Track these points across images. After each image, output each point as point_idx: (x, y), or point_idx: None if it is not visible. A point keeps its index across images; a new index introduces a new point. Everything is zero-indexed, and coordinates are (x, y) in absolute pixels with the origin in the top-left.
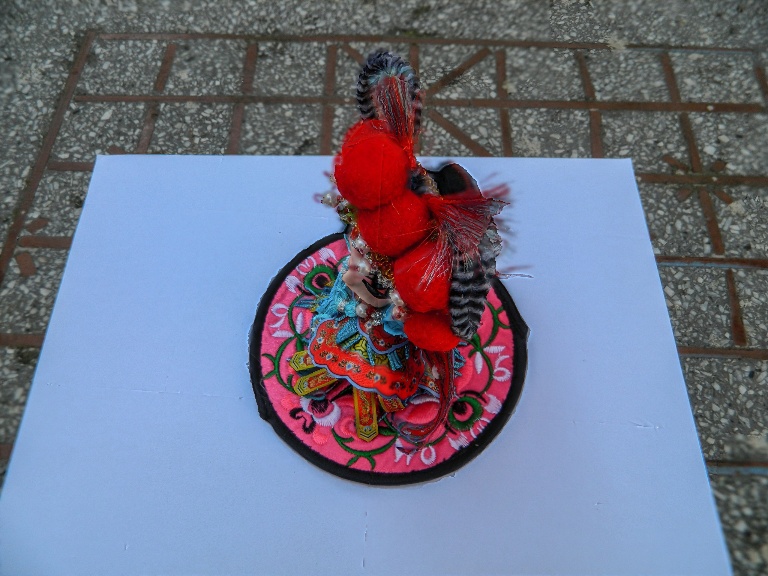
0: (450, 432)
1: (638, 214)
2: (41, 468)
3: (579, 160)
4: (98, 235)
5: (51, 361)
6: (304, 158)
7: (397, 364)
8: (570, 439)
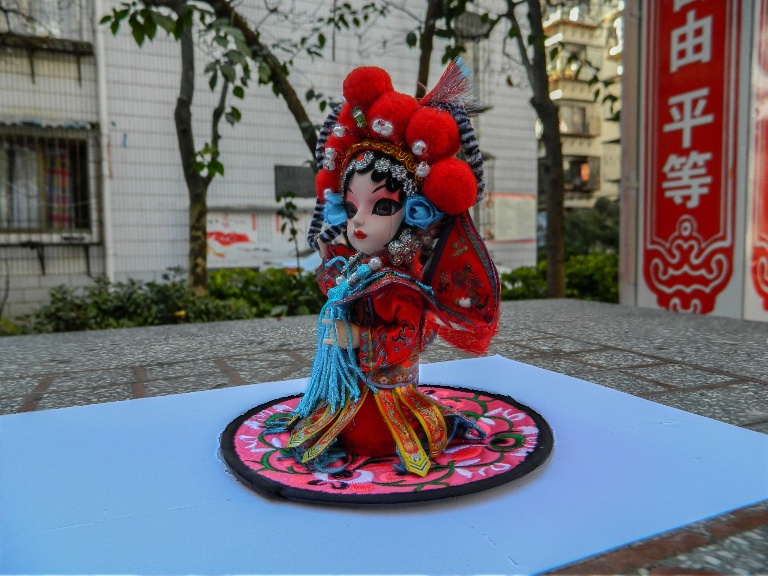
0: (506, 452)
1: (530, 367)
2: None
3: (462, 360)
4: None
5: None
6: (221, 389)
7: (428, 286)
8: (620, 439)
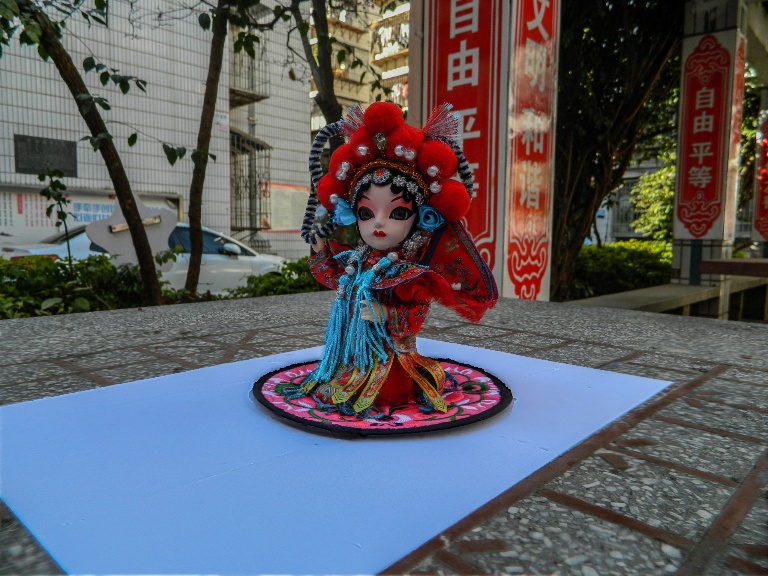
0: None
1: (427, 340)
2: (148, 568)
3: None
4: (1, 445)
5: (43, 514)
6: (185, 372)
7: None
8: (536, 381)
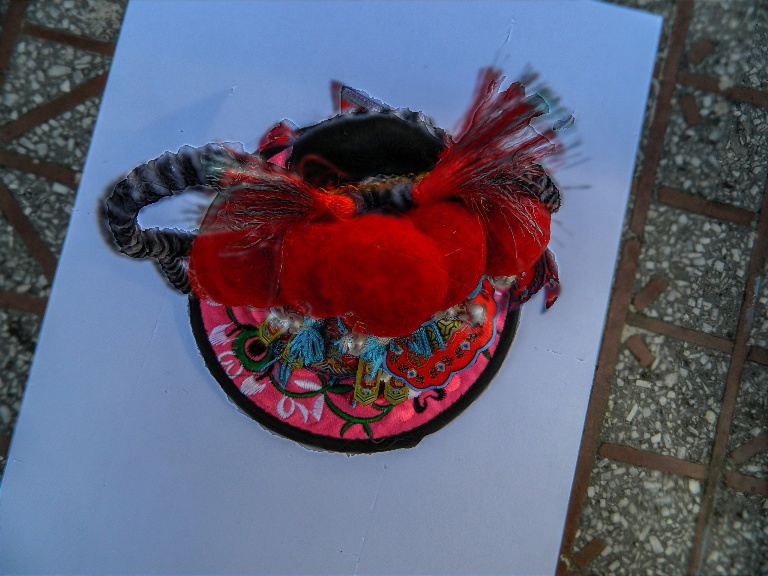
0: None
1: None
2: None
3: None
4: None
5: None
6: (43, 339)
7: None
8: None
